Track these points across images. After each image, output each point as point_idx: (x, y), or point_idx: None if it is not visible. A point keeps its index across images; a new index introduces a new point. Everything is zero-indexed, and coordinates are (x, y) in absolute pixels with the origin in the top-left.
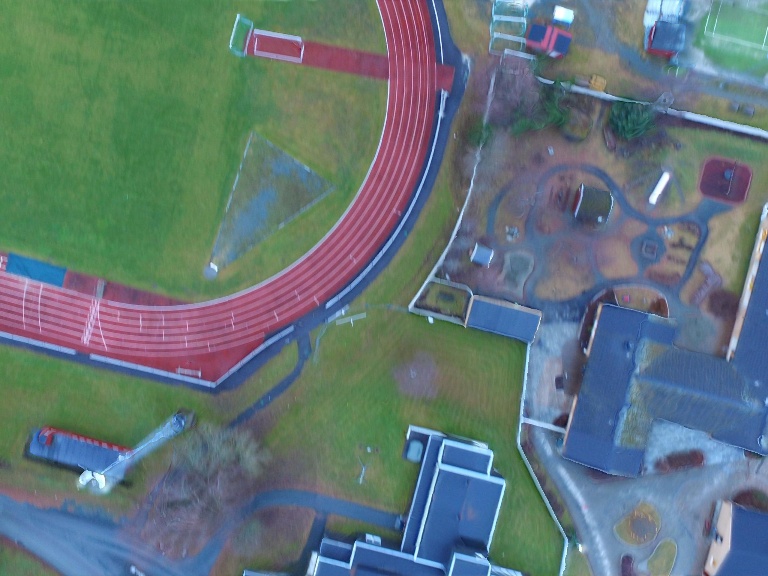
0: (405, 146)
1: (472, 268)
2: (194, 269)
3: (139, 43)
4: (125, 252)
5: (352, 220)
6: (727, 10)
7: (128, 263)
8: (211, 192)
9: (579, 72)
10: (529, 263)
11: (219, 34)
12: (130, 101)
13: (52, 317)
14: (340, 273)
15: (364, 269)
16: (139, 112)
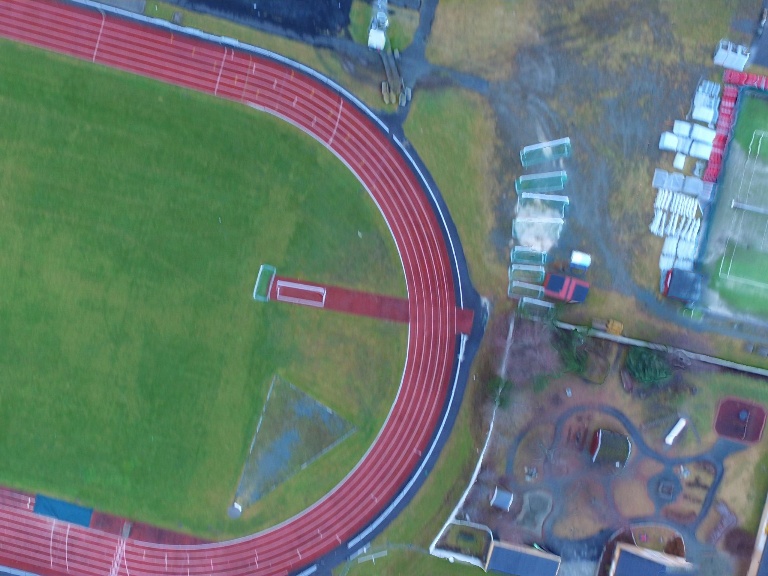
0: (425, 388)
1: (492, 511)
2: (218, 509)
3: (164, 289)
4: (151, 493)
5: (373, 460)
6: (741, 252)
7: (153, 503)
8: (235, 434)
9: (596, 315)
10: (548, 503)
11: (242, 280)
12: (155, 346)
13: (79, 557)
14: (362, 512)
15: (385, 509)
16: (164, 357)
